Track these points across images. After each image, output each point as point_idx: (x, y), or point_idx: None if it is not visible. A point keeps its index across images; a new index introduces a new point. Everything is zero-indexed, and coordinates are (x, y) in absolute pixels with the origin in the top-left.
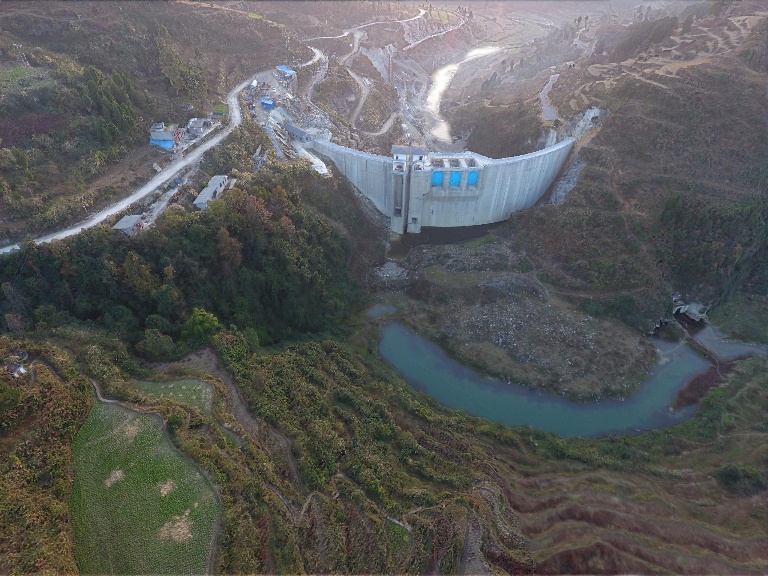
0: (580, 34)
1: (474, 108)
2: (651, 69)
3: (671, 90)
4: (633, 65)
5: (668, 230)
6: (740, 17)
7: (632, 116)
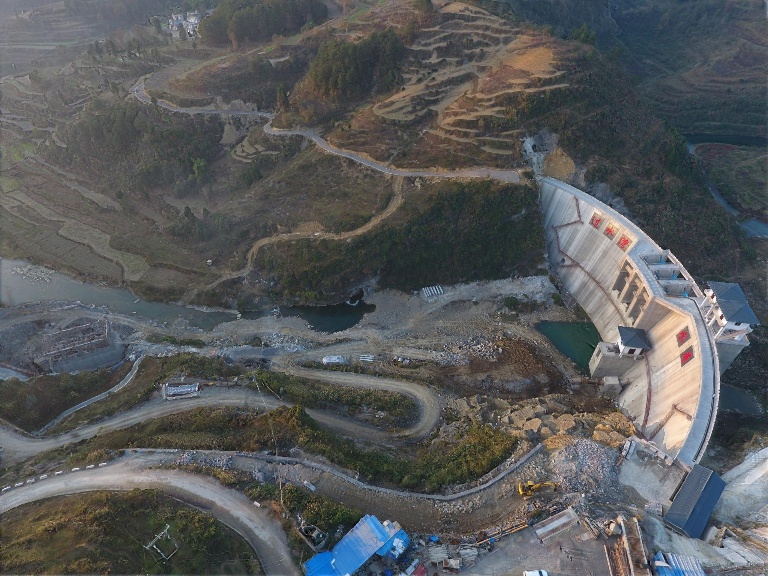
0: (178, 100)
1: (335, 252)
2: (520, 78)
3: (574, 84)
4: (428, 89)
5: (681, 175)
6: (452, 8)
7: (582, 122)
